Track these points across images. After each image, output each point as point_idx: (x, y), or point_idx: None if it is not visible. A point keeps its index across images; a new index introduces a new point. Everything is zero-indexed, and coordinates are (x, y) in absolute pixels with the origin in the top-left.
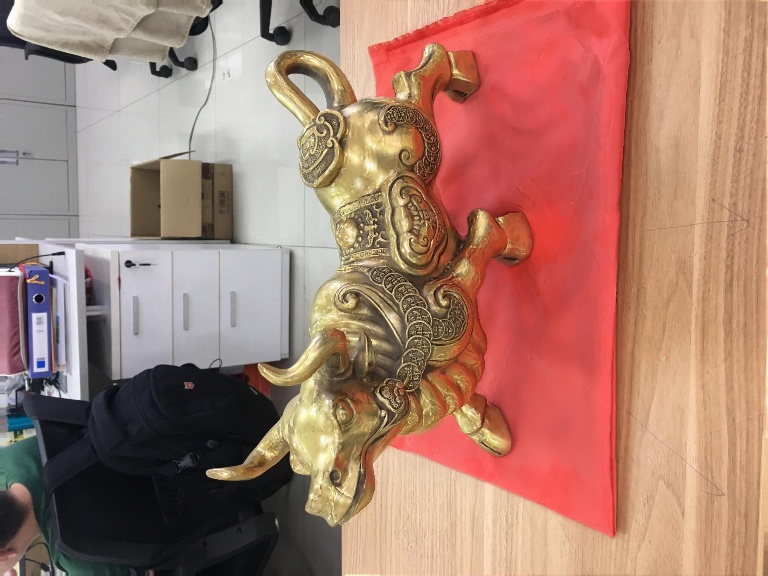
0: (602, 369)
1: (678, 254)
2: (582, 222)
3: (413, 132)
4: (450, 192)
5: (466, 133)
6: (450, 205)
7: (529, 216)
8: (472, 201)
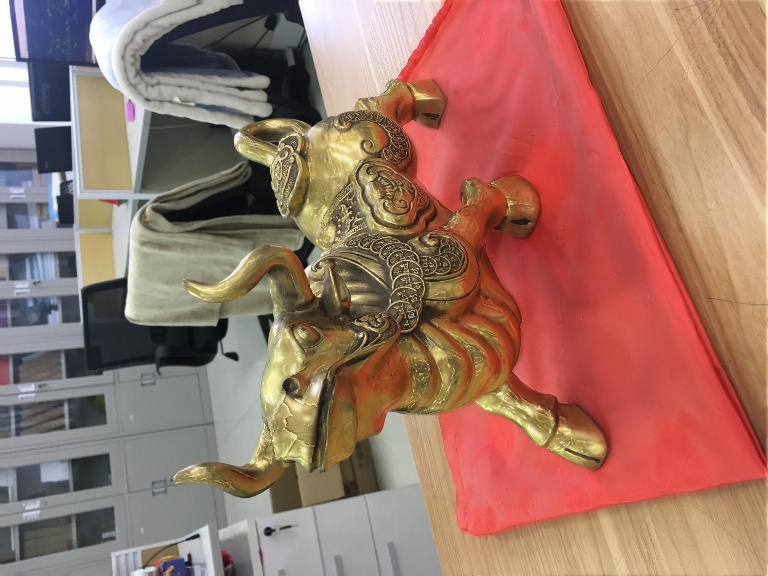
0: (651, 260)
1: (671, 87)
2: (570, 134)
3: (373, 127)
4: None
5: (449, 148)
6: None
7: (525, 174)
8: None
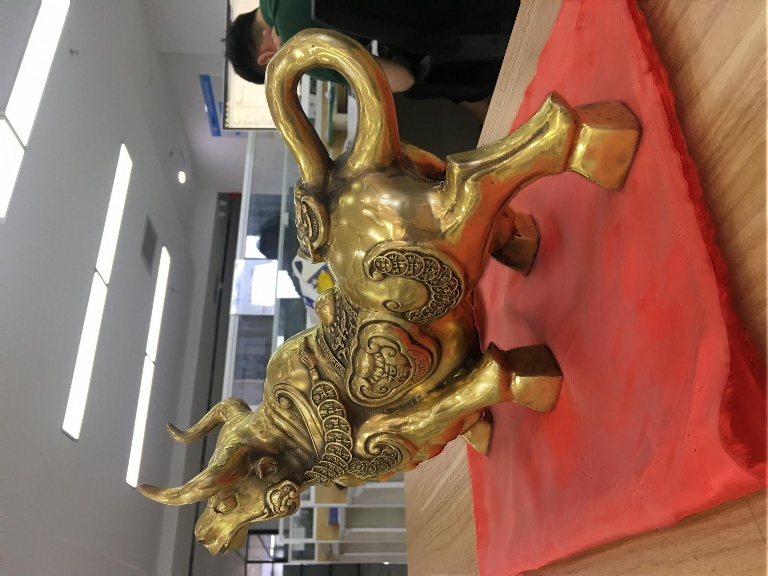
0: None
1: None
2: (566, 489)
3: (415, 282)
4: (551, 230)
5: (581, 214)
6: (546, 240)
7: (563, 390)
8: (553, 279)
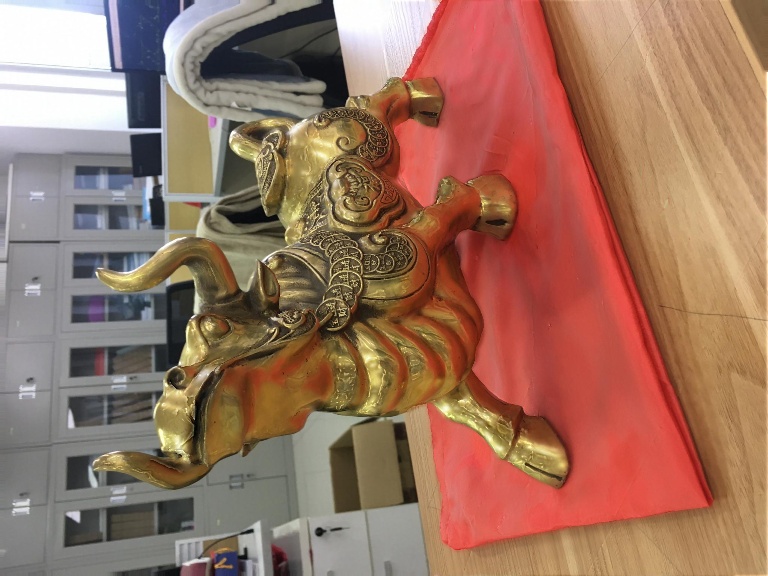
0: (603, 263)
1: (631, 76)
2: (541, 129)
3: (353, 124)
4: None
5: (444, 147)
6: None
7: (506, 173)
8: None
